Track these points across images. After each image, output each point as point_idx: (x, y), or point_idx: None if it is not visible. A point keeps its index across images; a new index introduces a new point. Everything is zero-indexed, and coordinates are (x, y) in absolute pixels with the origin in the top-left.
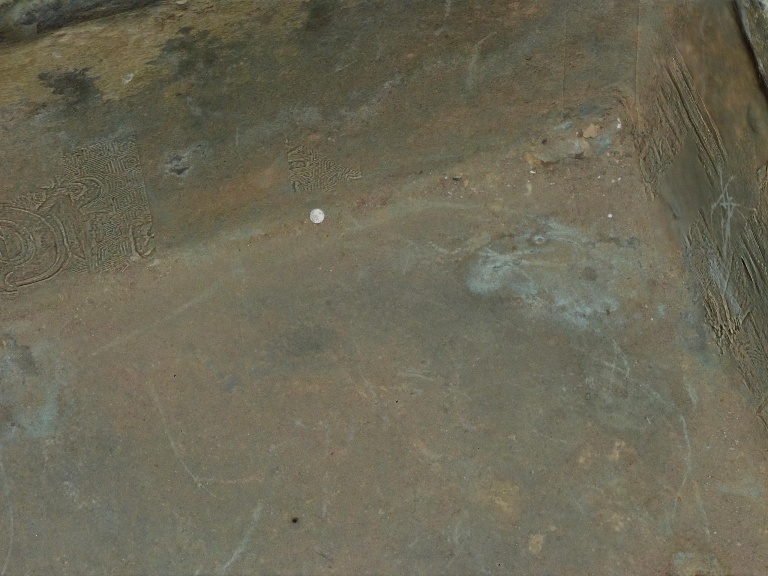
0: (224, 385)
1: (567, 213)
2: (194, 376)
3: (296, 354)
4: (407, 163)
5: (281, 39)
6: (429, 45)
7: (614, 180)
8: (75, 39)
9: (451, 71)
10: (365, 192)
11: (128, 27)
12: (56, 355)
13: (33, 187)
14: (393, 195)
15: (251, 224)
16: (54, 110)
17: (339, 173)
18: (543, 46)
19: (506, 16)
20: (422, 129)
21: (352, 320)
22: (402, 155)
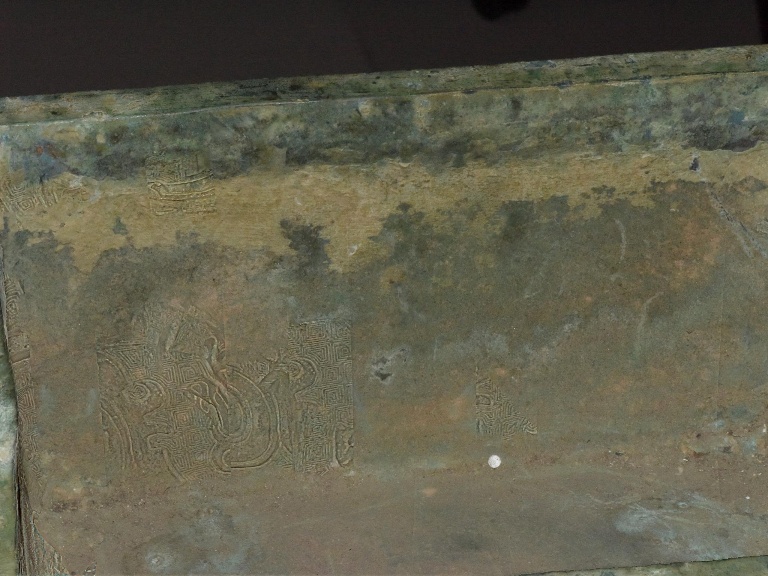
0: (391, 561)
1: (710, 491)
2: (367, 552)
3: (457, 550)
4: (578, 429)
5: (482, 244)
6: (605, 291)
7: (755, 474)
8: (315, 187)
9: (622, 329)
10: (539, 450)
11: (359, 188)
12: (253, 524)
13: (260, 355)
14: (562, 457)
15: (437, 457)
16: (288, 268)
17: (518, 423)
18: (702, 322)
19: (672, 275)
20: (593, 393)
21: (510, 535)
22: (574, 419)
